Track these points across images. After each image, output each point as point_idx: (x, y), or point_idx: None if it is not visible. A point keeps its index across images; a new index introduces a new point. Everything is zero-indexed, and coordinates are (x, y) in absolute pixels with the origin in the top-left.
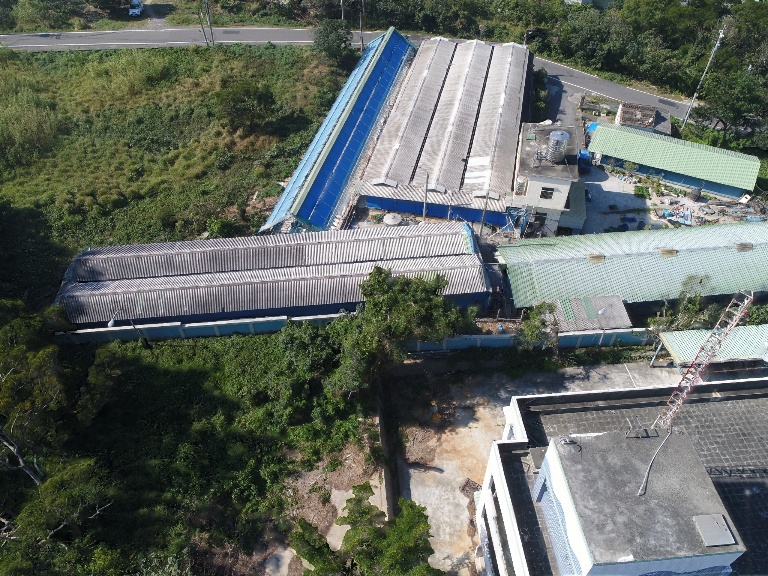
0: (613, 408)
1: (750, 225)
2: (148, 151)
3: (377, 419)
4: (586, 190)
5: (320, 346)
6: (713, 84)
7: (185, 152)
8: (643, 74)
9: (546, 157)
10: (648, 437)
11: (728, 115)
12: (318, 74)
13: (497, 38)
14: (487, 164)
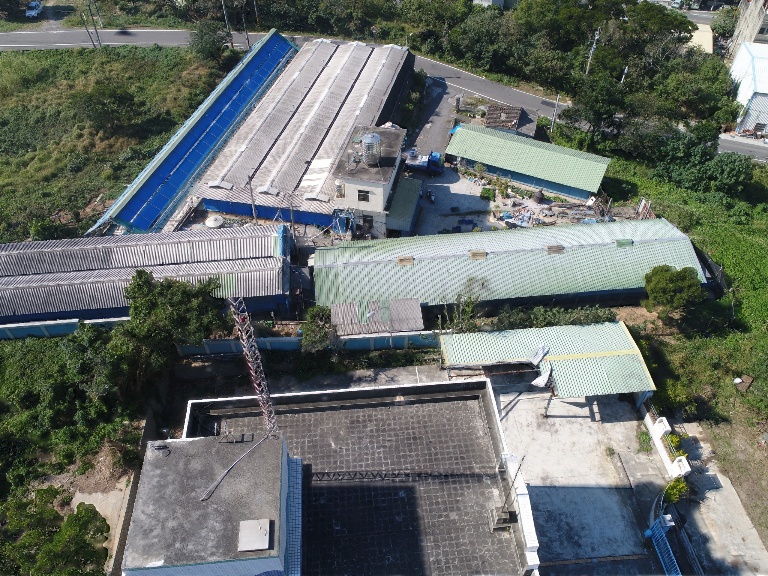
0: (296, 412)
1: (573, 227)
2: (5, 153)
3: (144, 422)
4: (429, 192)
5: (99, 349)
6: (578, 86)
7: (41, 154)
8: (531, 76)
9: (363, 160)
10: (241, 442)
11: (589, 117)
12: (192, 76)
13: (391, 40)
14: (327, 166)
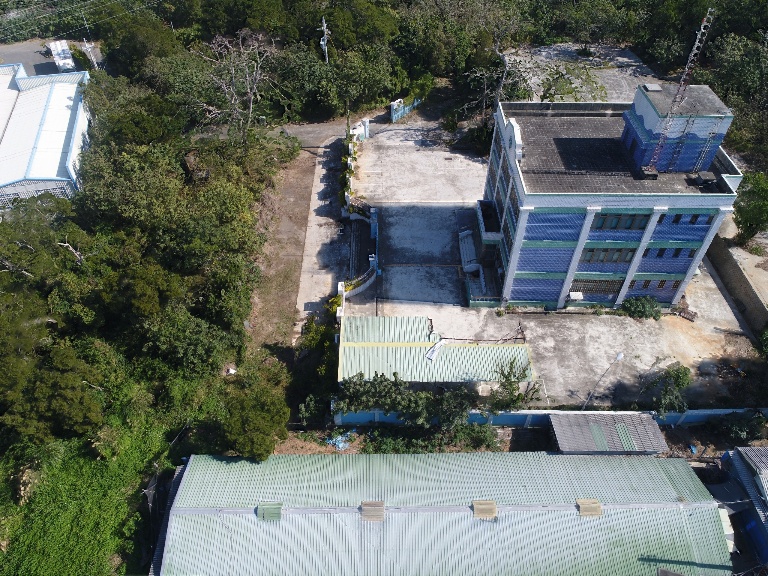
0: None
1: None
2: None
3: None
4: None
5: None
6: None
7: None
8: None
9: None
10: (681, 113)
11: None
12: None
13: None
14: None
